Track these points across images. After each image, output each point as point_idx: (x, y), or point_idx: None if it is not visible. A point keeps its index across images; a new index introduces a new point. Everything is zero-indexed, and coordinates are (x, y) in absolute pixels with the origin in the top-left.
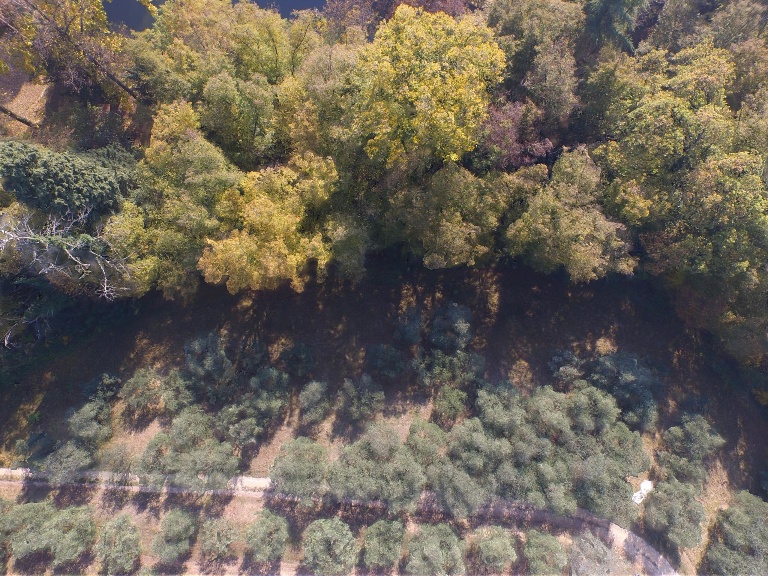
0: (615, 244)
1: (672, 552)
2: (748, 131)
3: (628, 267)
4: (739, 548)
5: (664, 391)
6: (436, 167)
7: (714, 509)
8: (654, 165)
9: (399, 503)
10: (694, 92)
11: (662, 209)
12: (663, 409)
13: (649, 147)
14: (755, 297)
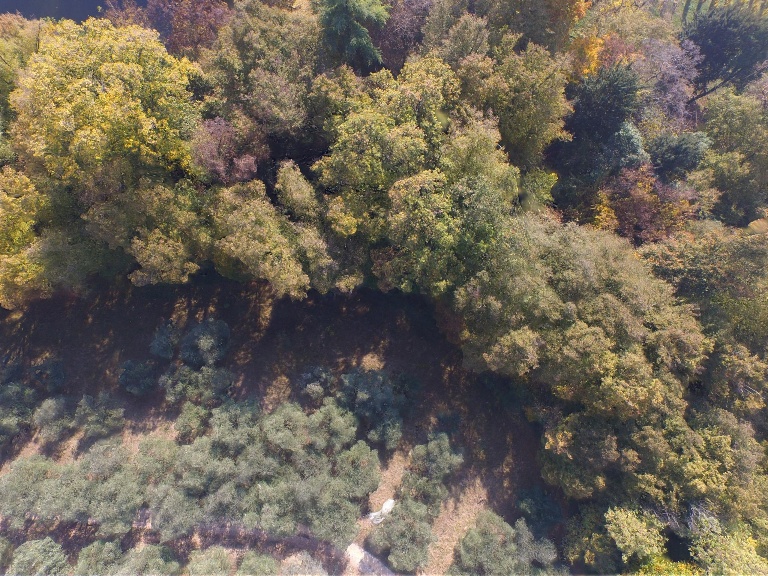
0: (322, 262)
1: (409, 573)
2: (448, 148)
3: (349, 284)
4: (471, 569)
5: (428, 408)
6: (171, 181)
7: (463, 528)
8: (380, 181)
9: (110, 524)
10: (401, 108)
11: (374, 226)
12: (422, 426)
13: (347, 164)
14: (478, 315)
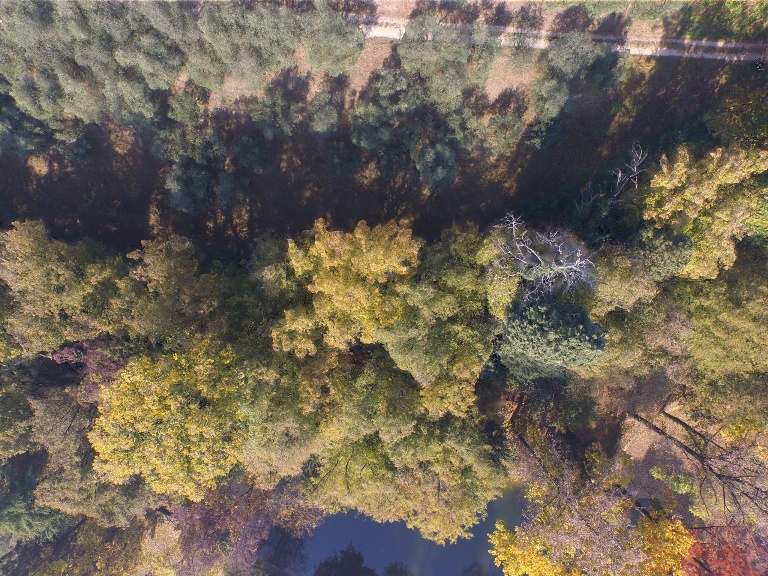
0: None
1: None
2: None
3: None
4: None
5: None
6: None
7: None
8: None
9: (225, 0)
10: None
11: None
12: None
13: None
14: None
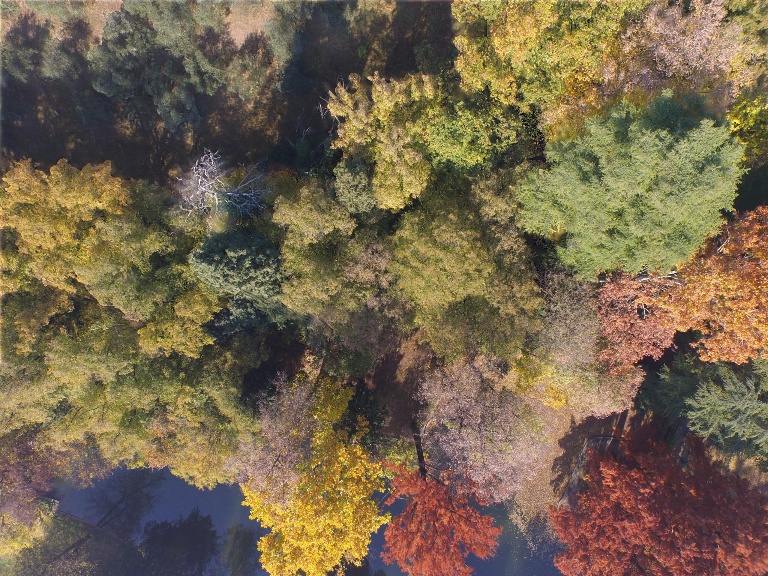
0: None
1: None
2: None
3: None
4: None
5: None
6: None
7: None
8: None
9: None
10: None
11: None
12: None
13: None
14: None
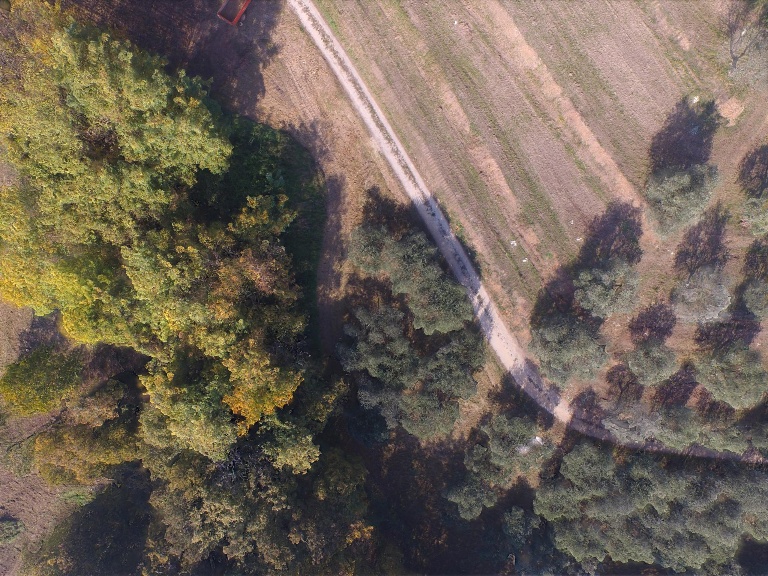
0: None
1: (510, 389)
2: None
3: None
4: None
5: None
6: None
7: None
8: None
9: None
10: None
11: None
12: None
13: None
14: None
